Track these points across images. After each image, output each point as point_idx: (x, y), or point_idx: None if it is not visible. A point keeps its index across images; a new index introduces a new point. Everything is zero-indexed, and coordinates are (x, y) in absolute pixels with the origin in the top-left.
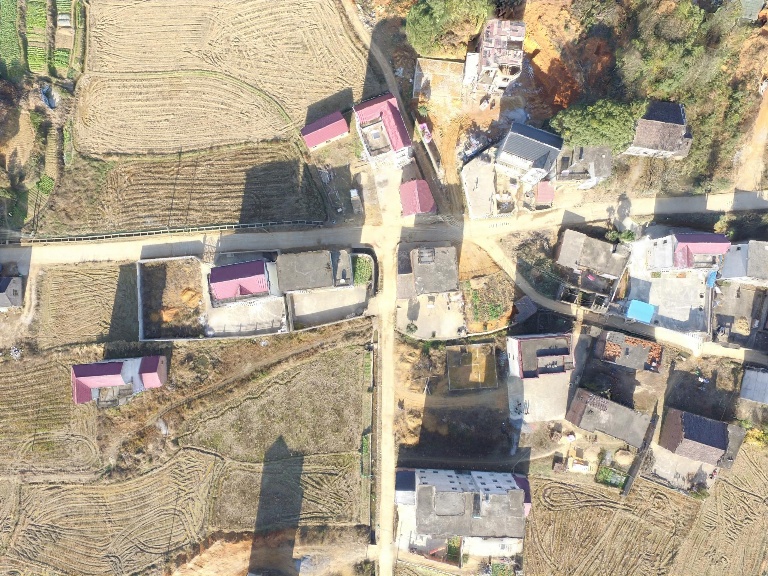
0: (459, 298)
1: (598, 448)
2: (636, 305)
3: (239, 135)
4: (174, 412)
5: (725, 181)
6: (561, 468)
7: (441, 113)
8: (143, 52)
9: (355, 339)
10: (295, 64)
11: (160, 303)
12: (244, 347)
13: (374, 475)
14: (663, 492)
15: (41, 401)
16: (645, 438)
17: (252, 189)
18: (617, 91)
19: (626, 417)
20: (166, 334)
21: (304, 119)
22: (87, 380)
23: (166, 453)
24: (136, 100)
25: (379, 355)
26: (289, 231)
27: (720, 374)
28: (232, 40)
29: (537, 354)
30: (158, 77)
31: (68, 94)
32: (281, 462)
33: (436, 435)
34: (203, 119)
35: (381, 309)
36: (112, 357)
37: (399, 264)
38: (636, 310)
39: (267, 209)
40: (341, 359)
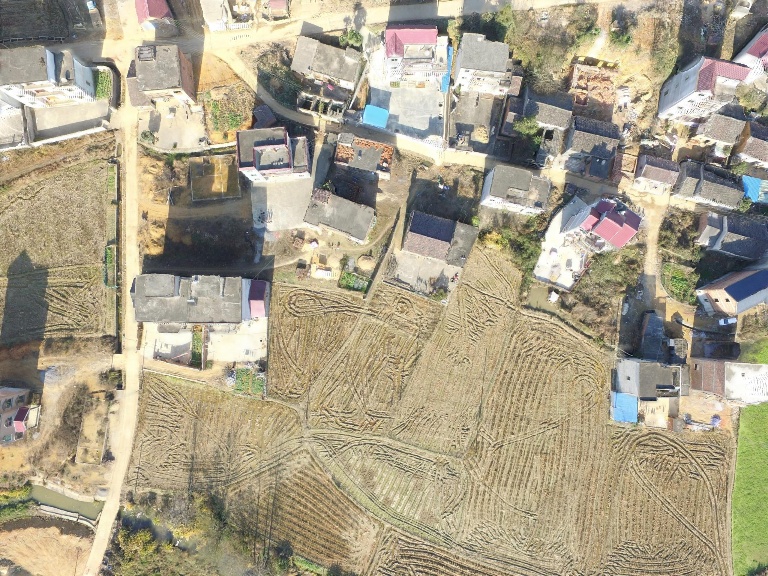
0: (200, 109)
1: (341, 254)
2: (370, 110)
3: None
4: None
5: None
6: (302, 273)
7: None
8: None
9: (97, 152)
10: None
11: None
12: None
13: (119, 286)
14: (406, 297)
15: None
16: (387, 244)
17: None
18: None
19: (350, 210)
20: None
21: None
22: None
23: None
24: None
25: (123, 168)
26: None
27: (461, 182)
28: None
29: (255, 145)
30: None
31: None
32: (25, 276)
33: (180, 245)
34: None
35: (124, 122)
36: None
37: (130, 69)
38: (371, 115)
39: (8, 26)
40: (85, 173)
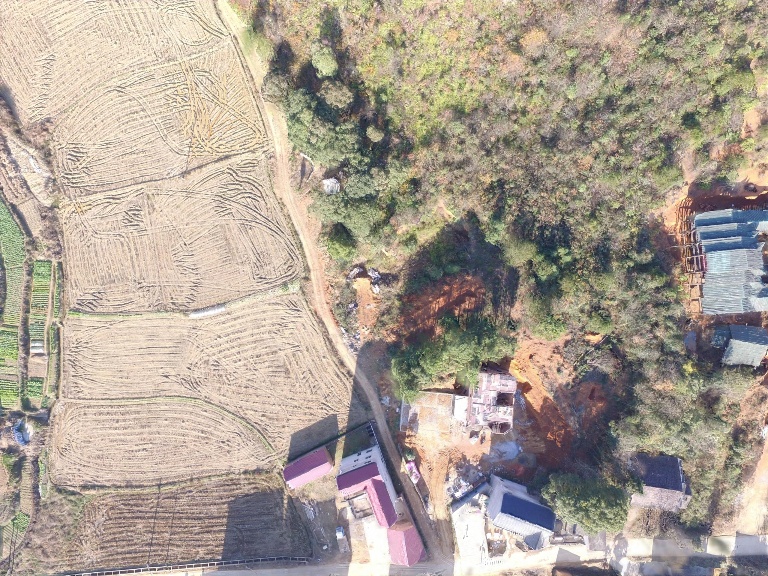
0: None
1: None
2: None
3: (220, 465)
4: None
5: None
6: None
7: (429, 446)
8: (119, 377)
9: None
10: (277, 389)
11: None
12: None
13: None
14: None
15: None
16: None
17: (234, 523)
18: (612, 458)
19: None
20: None
21: (287, 448)
22: None
23: None
24: (113, 428)
25: None
26: (273, 568)
27: None
28: (212, 363)
29: None
30: (135, 403)
31: (42, 427)
32: None
33: None
34: (183, 448)
35: None
36: None
37: None
38: None
39: (250, 544)
40: None
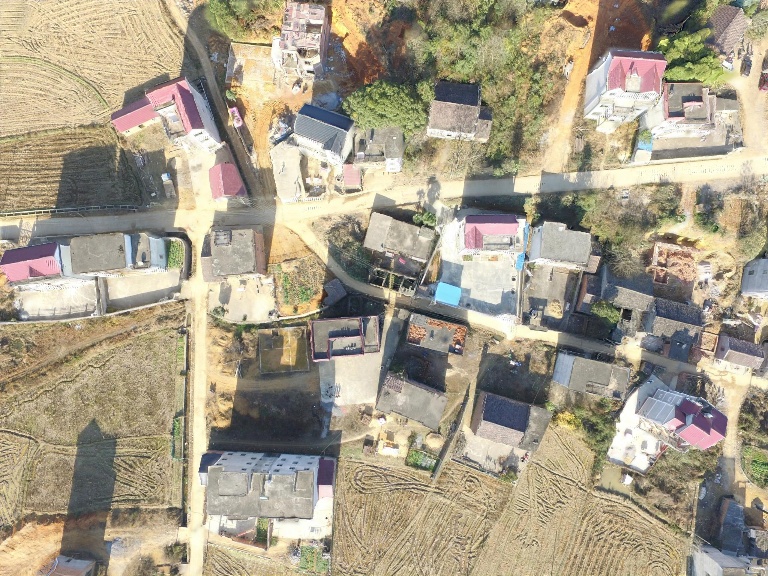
0: (270, 281)
1: (409, 431)
2: (443, 288)
3: (57, 120)
4: None
5: (531, 163)
6: (370, 451)
7: (254, 97)
8: None
9: (168, 323)
10: (113, 50)
11: None
12: (59, 331)
13: (186, 458)
14: (475, 475)
15: None
16: (456, 421)
17: (69, 174)
18: (410, 73)
19: (423, 399)
20: None
21: (121, 104)
22: None
23: None
24: None
25: (192, 338)
26: (104, 215)
27: (533, 357)
28: (52, 26)
29: (329, 335)
30: None
31: None
32: (94, 445)
33: (247, 418)
34: (22, 105)
35: (194, 293)
36: None
37: (203, 247)
38: (443, 293)
39: (83, 194)
40: (155, 343)
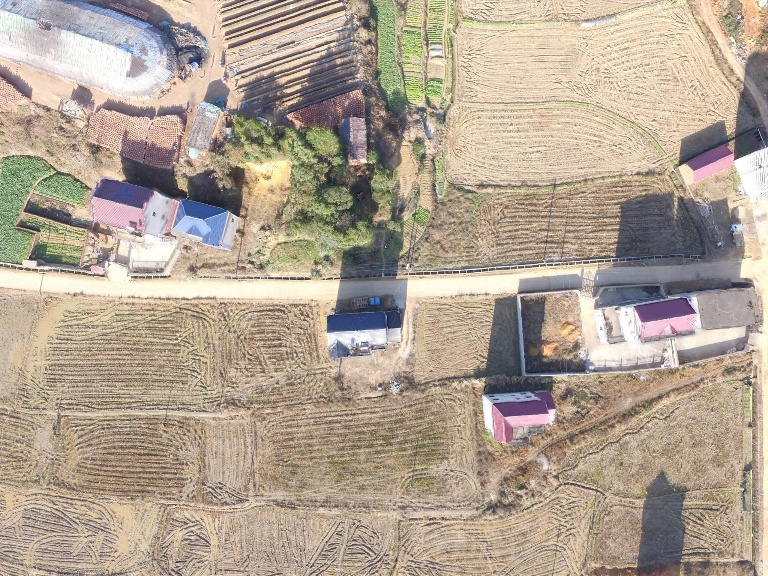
0: None
1: None
2: None
3: (613, 167)
4: (556, 447)
5: None
6: None
7: None
8: (513, 83)
9: (736, 374)
10: (667, 96)
11: (539, 337)
12: (624, 382)
13: (756, 511)
14: None
15: (419, 436)
16: None
17: (627, 222)
18: None
19: None
20: (549, 369)
21: (678, 152)
22: (513, 419)
23: (549, 489)
24: (507, 131)
25: (758, 390)
26: (667, 265)
27: None
28: (602, 71)
29: None
30: (528, 108)
31: (443, 125)
32: (662, 498)
33: None
34: (575, 151)
35: (761, 344)
36: (493, 392)
37: None
38: None
39: (643, 242)
40: (720, 394)
